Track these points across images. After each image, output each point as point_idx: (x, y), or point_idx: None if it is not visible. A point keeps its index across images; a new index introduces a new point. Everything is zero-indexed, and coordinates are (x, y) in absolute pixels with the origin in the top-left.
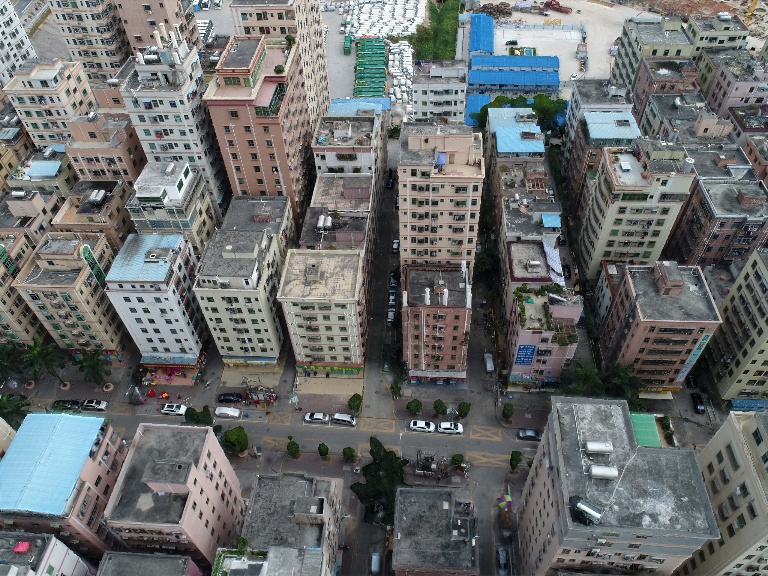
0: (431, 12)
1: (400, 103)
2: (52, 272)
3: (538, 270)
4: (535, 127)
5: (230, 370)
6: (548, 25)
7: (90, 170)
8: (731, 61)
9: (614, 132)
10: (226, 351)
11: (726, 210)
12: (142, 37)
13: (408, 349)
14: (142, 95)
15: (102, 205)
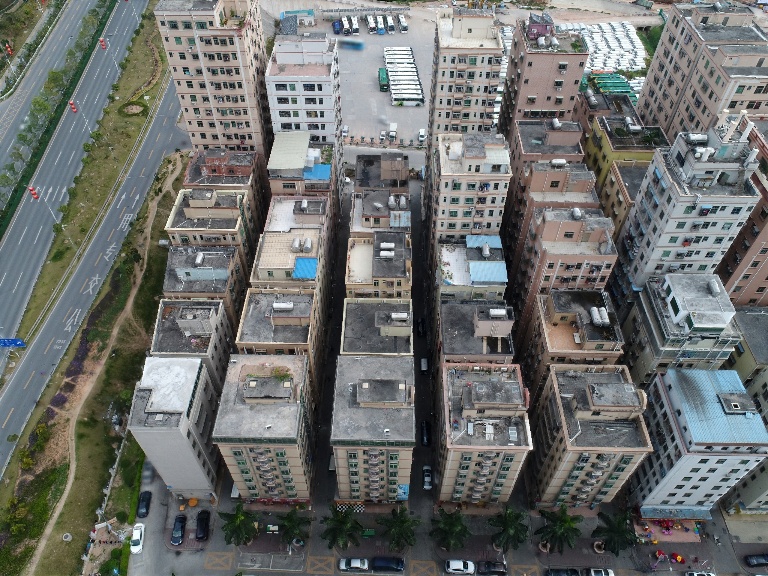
0: (644, 42)
1: None
2: (594, 424)
3: None
4: None
5: (732, 519)
6: None
7: (559, 276)
8: None
9: None
10: (760, 505)
11: None
12: (536, 99)
13: None
14: (706, 200)
15: (610, 328)
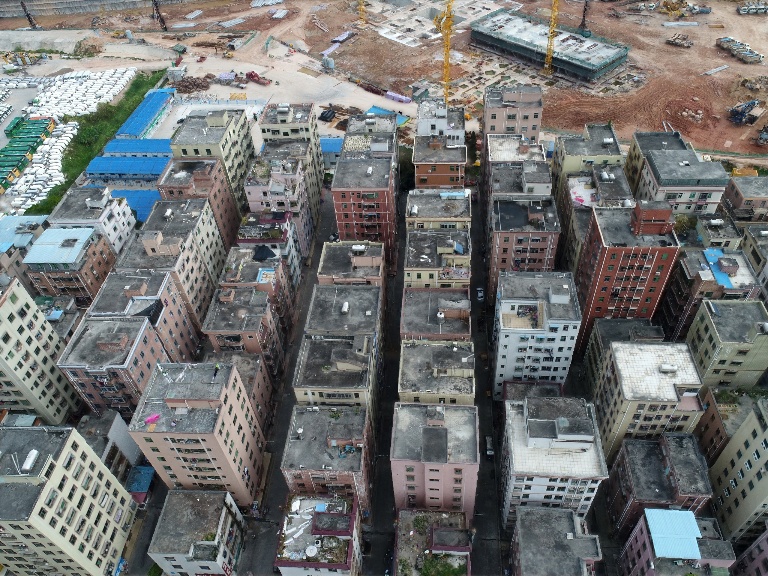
0: (131, 86)
1: (16, 195)
2: None
3: None
4: (7, 244)
5: None
6: (233, 100)
7: None
8: (263, 160)
9: (51, 255)
10: None
11: (80, 357)
12: None
13: None
14: None
15: None
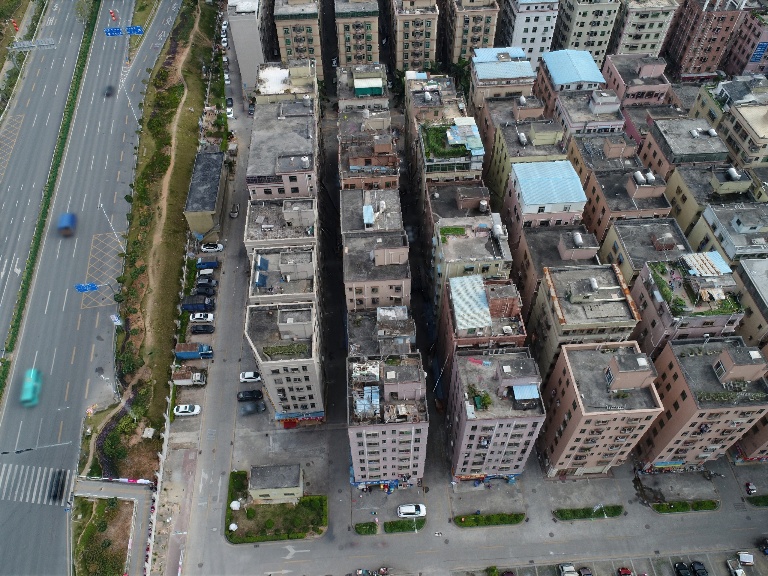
0: None
1: None
2: (471, 7)
3: (755, 4)
4: None
5: None
6: None
7: None
8: None
9: None
10: None
11: None
12: None
13: (688, 53)
14: None
15: None
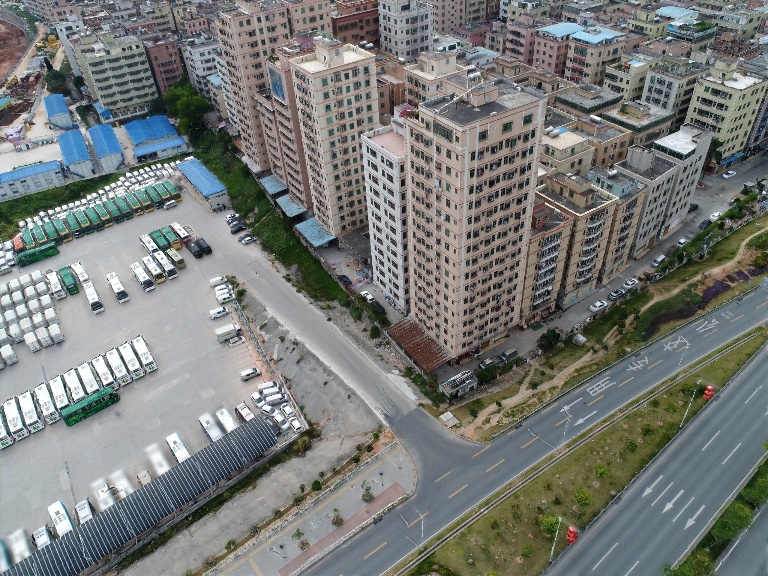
0: None
1: None
2: None
3: None
4: None
5: None
6: None
7: None
8: None
9: None
10: None
11: None
12: None
13: None
14: (425, 6)
15: None
